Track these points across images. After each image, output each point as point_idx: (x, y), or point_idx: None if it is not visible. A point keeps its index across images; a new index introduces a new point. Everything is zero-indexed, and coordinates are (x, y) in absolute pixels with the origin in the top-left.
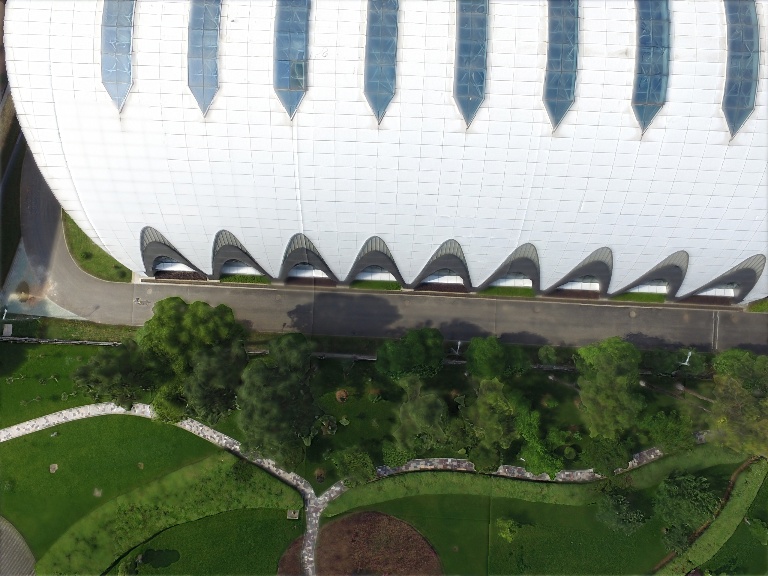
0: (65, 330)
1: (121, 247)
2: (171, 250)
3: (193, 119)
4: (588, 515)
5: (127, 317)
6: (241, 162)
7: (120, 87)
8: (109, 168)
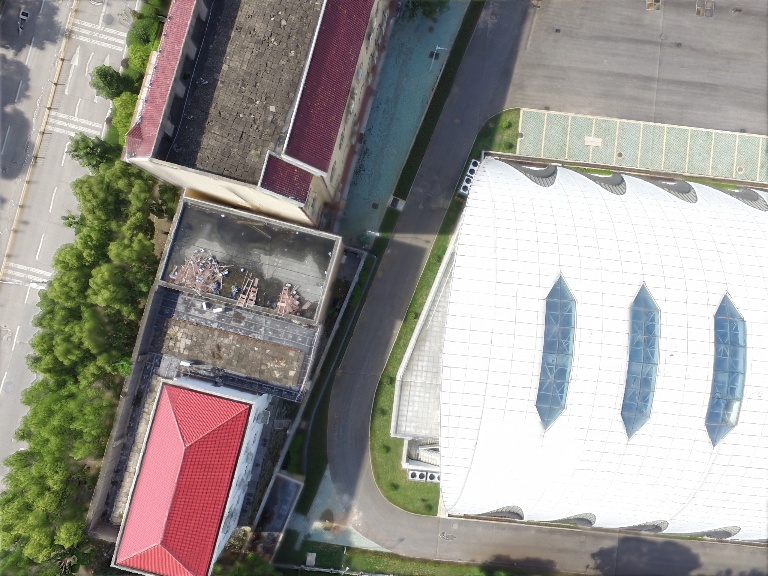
0: (369, 561)
1: (468, 510)
2: (518, 516)
3: (616, 441)
4: None
5: (432, 551)
6: (646, 475)
7: (552, 410)
8: (511, 471)
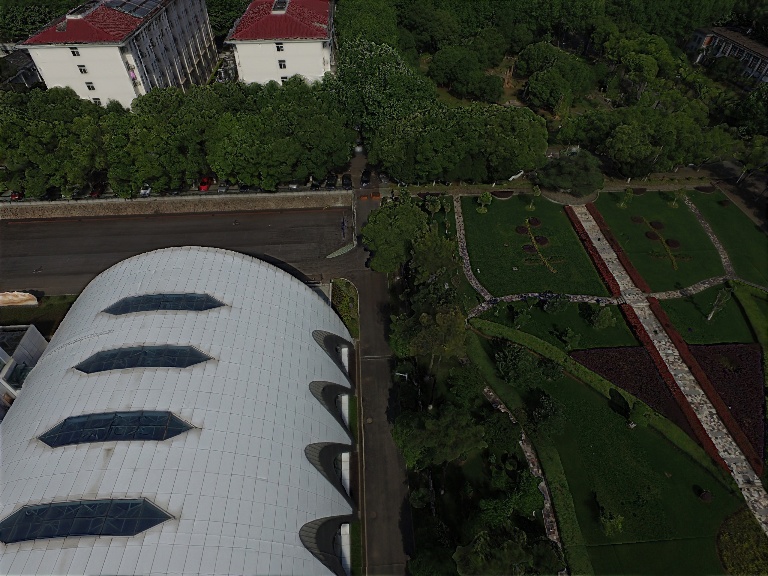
0: None
1: None
2: None
3: None
4: (562, 442)
5: None
6: None
7: None
8: None
